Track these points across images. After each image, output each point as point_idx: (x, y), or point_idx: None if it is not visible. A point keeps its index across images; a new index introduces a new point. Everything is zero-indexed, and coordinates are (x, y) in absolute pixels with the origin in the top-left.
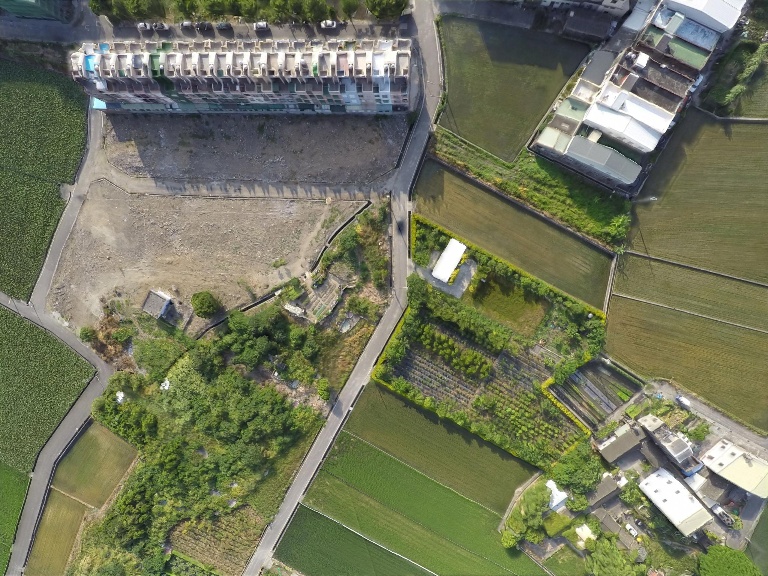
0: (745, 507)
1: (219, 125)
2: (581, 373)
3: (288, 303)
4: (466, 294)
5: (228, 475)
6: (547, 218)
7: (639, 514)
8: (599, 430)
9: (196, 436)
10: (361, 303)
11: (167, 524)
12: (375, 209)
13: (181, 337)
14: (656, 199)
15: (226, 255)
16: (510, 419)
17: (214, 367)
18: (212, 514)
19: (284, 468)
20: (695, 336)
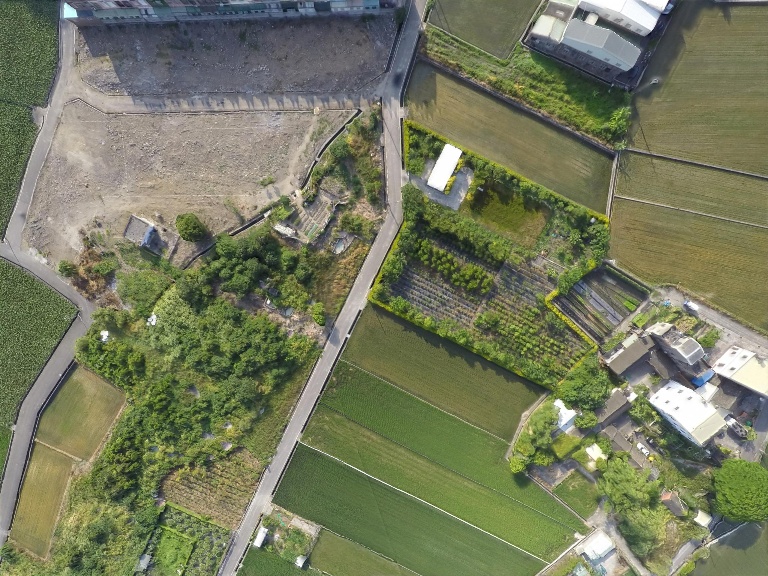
0: (758, 418)
1: (198, 34)
2: (585, 284)
3: (278, 223)
4: (463, 205)
5: (222, 414)
6: (544, 118)
7: (650, 431)
8: (606, 342)
9: (187, 374)
10: (355, 220)
11: (160, 472)
12: (365, 118)
13: (167, 266)
14: (657, 81)
15: (211, 175)
16: (514, 337)
17: (203, 297)
18: (207, 459)
19: (281, 405)
20: (701, 237)
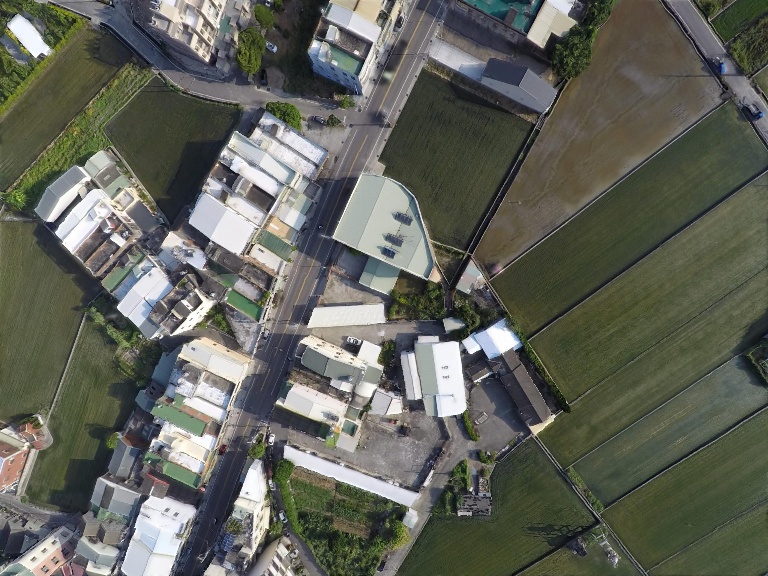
0: None
1: None
2: None
3: None
4: (2, 48)
5: None
6: None
7: None
8: None
9: None
10: None
11: None
12: None
13: None
14: None
15: None
16: None
17: None
18: None
19: None
20: None
